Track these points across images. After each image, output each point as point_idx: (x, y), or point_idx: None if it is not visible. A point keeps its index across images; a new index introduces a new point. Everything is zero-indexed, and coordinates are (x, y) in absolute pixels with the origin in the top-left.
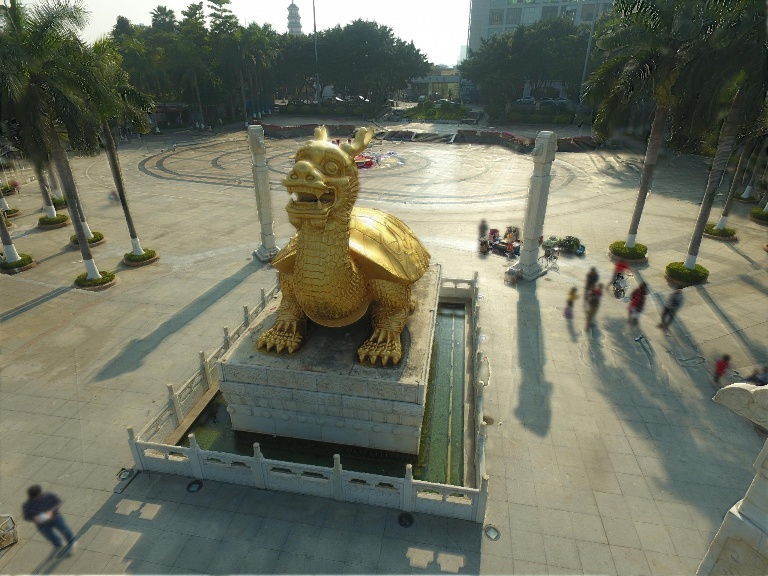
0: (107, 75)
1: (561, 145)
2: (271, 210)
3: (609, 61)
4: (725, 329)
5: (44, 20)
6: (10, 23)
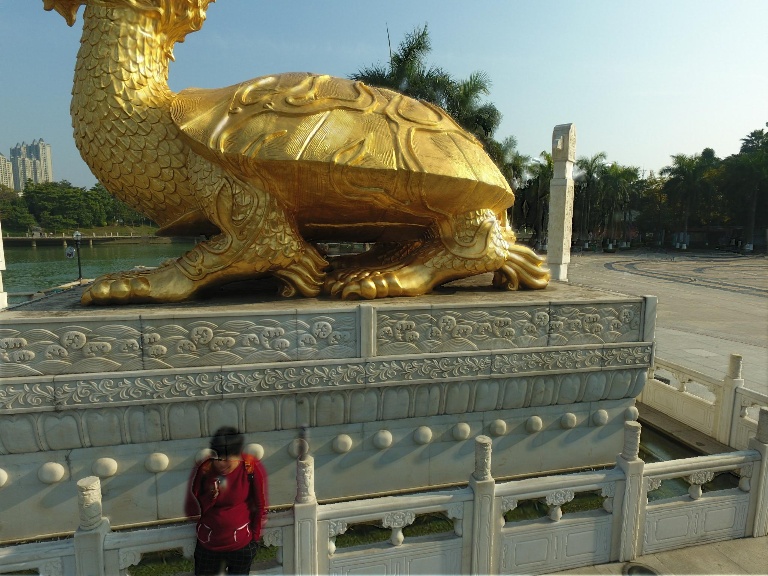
0: (474, 110)
1: None
2: (561, 244)
3: None
4: None
5: (406, 55)
6: (391, 66)
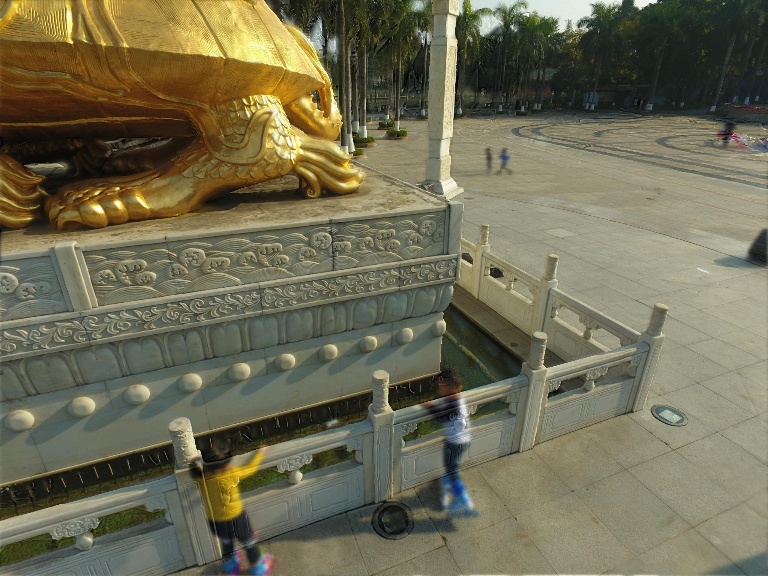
0: None
1: None
2: (442, 116)
3: None
4: None
5: None
6: None
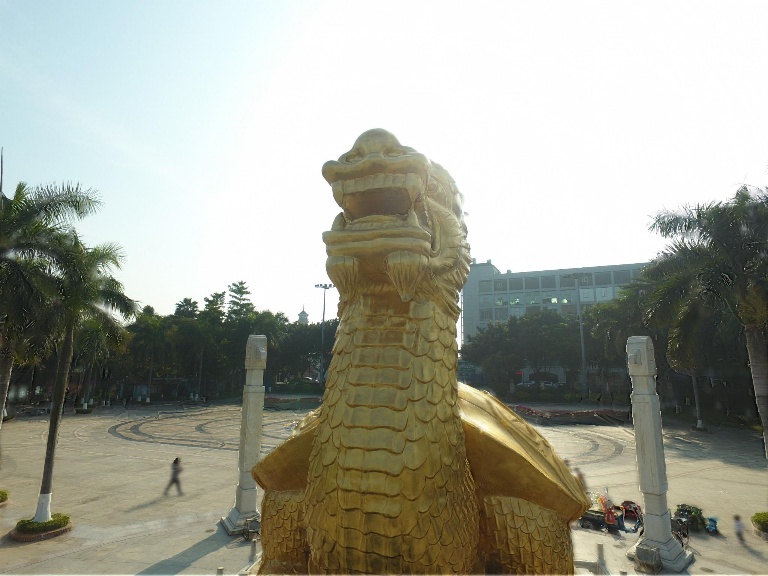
0: (96, 281)
1: (585, 418)
2: (259, 449)
3: (611, 337)
4: None
5: (40, 202)
6: None
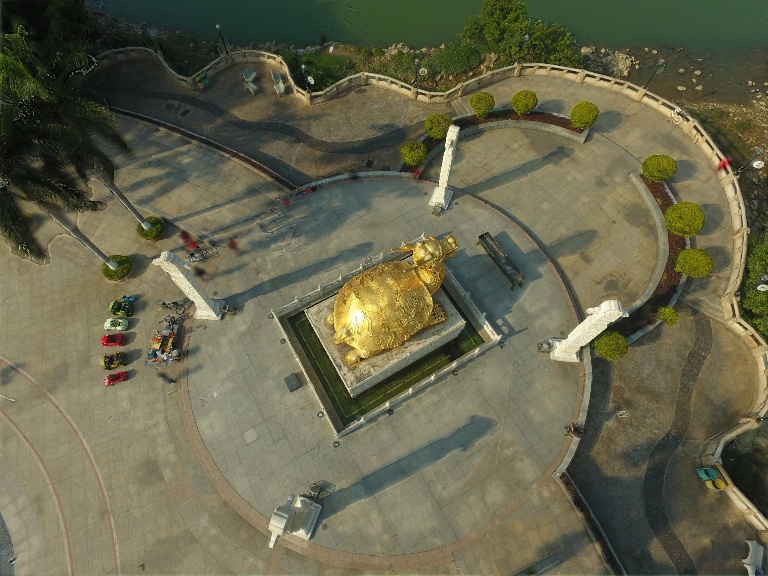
0: None
1: None
2: None
3: None
4: (232, 205)
5: None
6: None
